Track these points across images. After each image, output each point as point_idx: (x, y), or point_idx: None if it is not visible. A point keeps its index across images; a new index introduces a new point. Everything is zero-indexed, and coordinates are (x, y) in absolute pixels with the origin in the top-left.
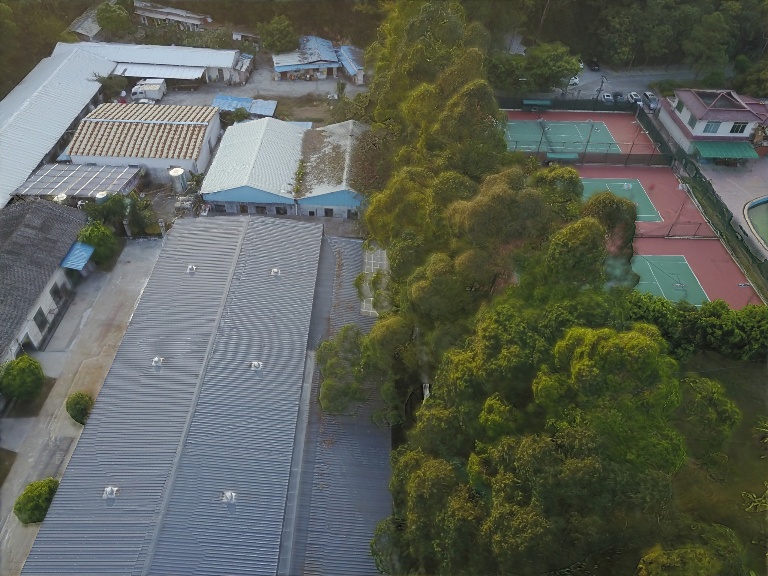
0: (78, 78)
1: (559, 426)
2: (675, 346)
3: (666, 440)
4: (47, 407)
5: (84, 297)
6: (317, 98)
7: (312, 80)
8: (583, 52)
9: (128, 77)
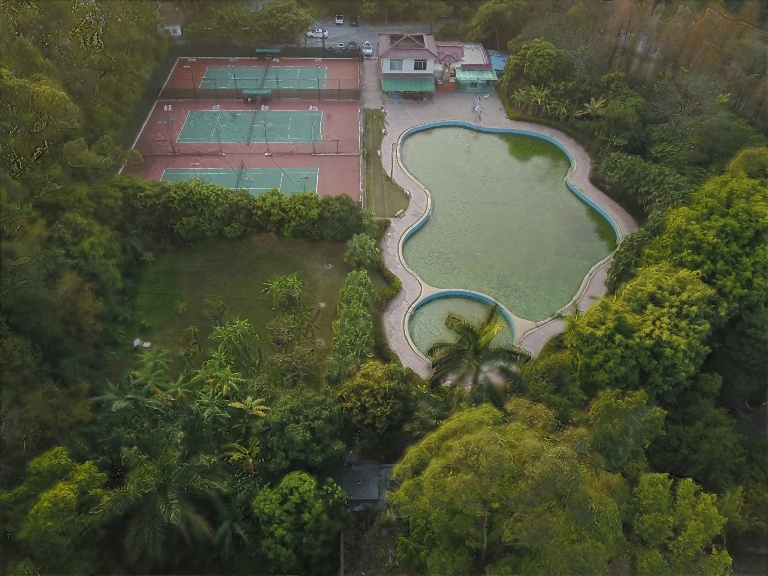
0: None
1: None
2: (226, 225)
3: None
4: None
5: None
6: None
7: None
8: (348, 10)
9: None
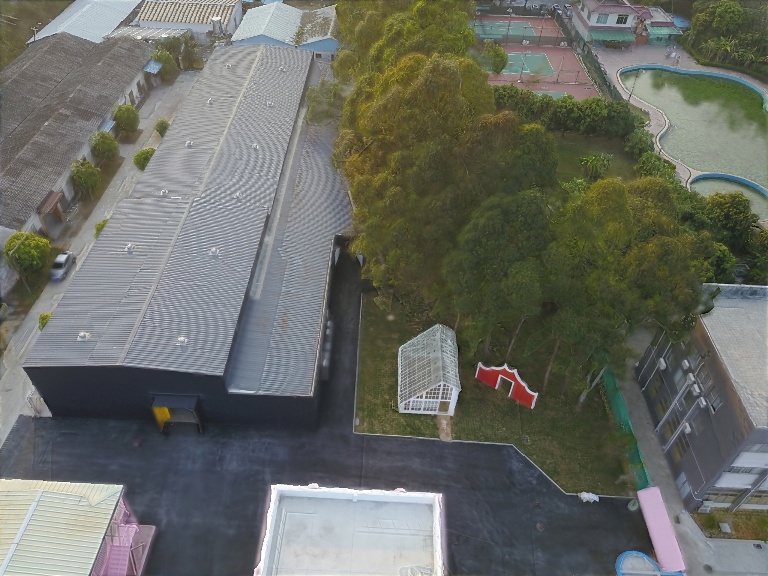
0: None
1: None
2: None
3: None
4: (140, 141)
5: (156, 96)
6: (313, 1)
7: None
8: None
9: None
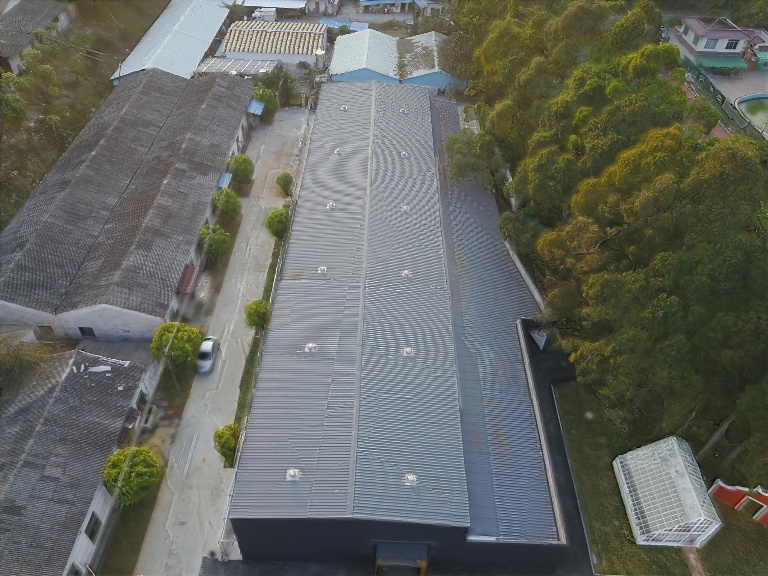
0: (212, 4)
1: (623, 101)
2: None
3: (680, 98)
4: (254, 193)
5: (257, 138)
6: (396, 24)
7: (389, 13)
8: None
9: (247, 7)
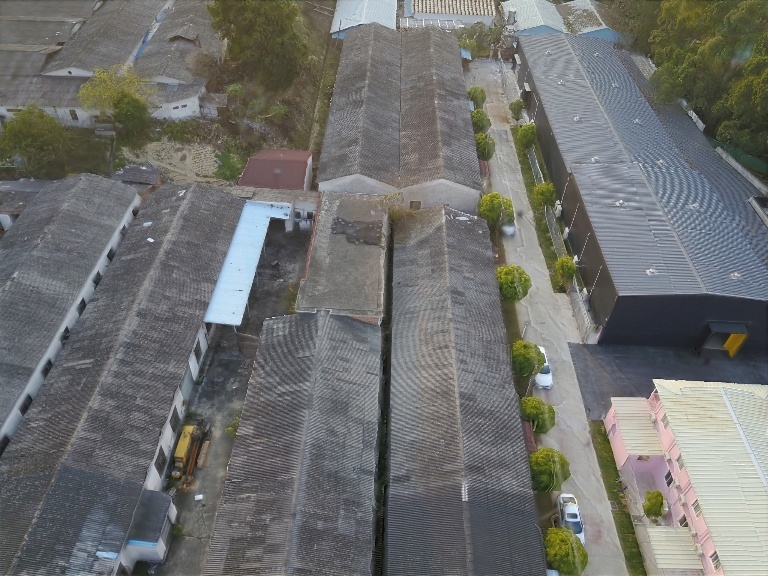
0: None
1: None
2: None
3: None
4: None
5: None
6: None
7: None
8: None
9: None
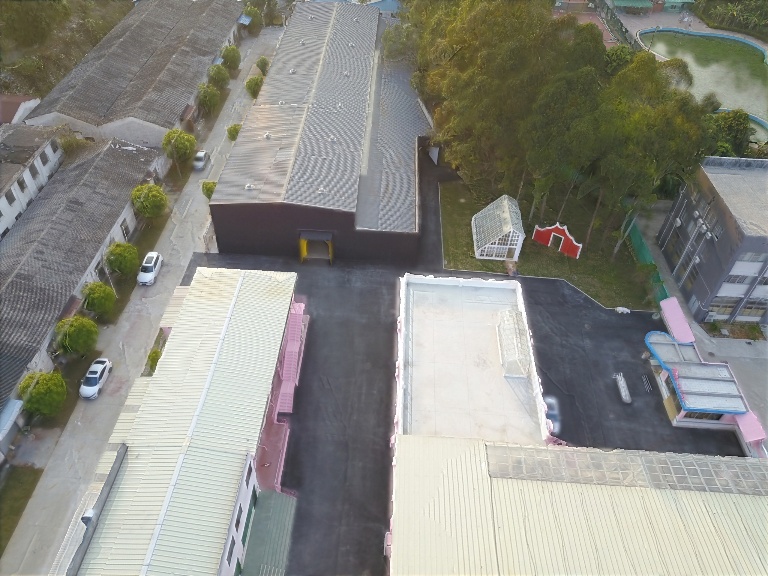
0: None
1: None
2: None
3: None
4: (240, 77)
5: (246, 45)
6: None
7: None
8: None
9: None
